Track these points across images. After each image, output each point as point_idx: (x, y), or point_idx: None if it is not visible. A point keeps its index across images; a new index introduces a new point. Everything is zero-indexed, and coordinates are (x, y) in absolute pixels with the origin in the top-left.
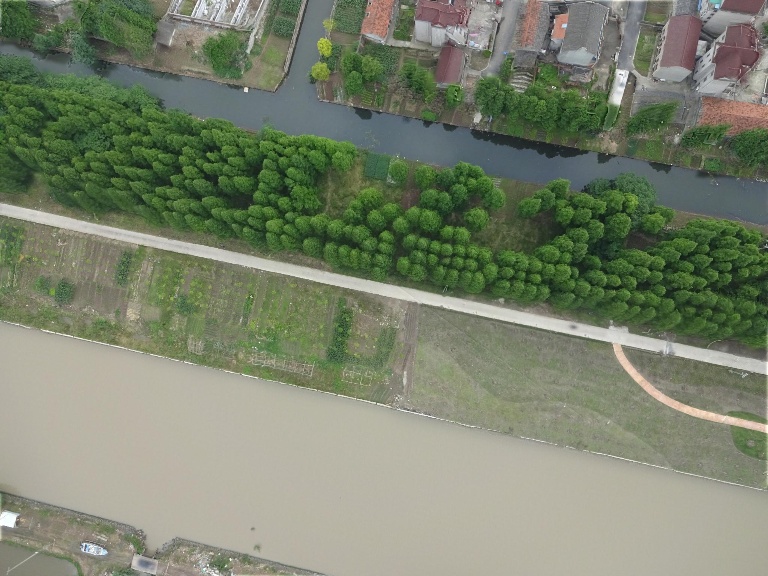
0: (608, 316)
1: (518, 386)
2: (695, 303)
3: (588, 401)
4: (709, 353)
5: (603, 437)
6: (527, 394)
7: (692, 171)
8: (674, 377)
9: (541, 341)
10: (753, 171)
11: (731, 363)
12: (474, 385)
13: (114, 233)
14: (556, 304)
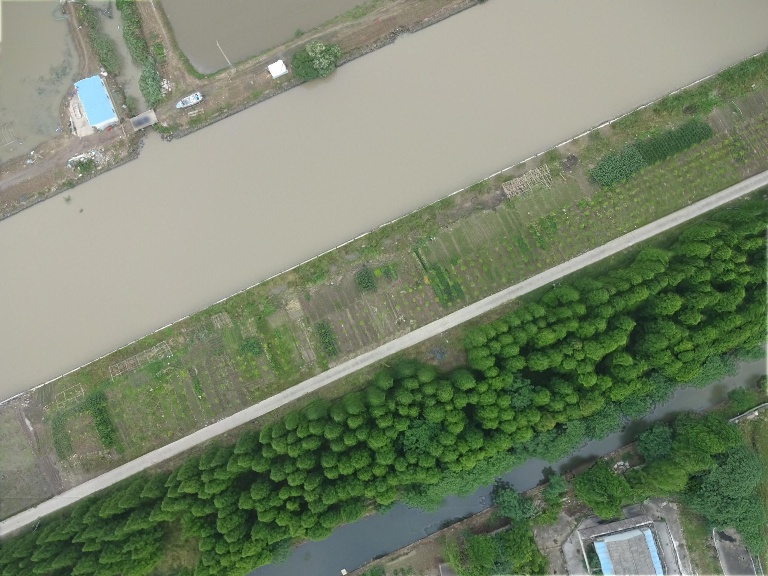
0: None
1: None
2: None
3: None
4: None
5: None
6: None
7: None
8: None
9: None
10: None
11: None
12: None
13: (360, 363)
14: None
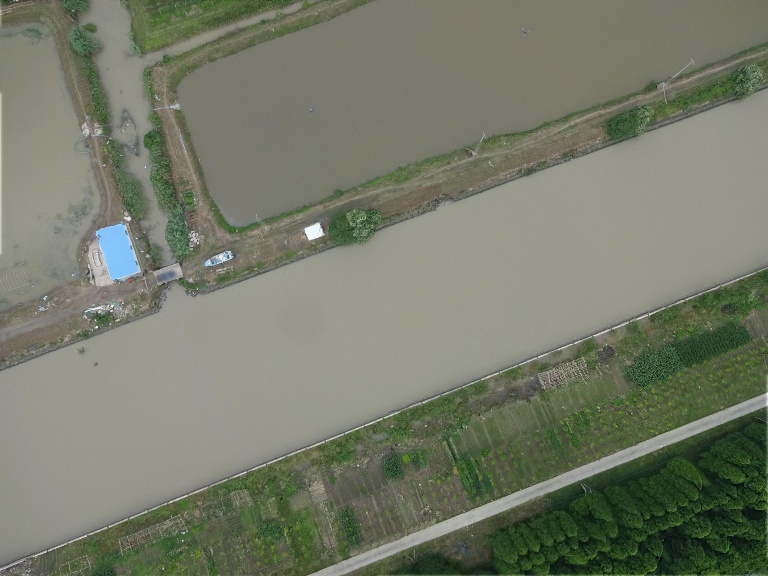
0: None
1: None
2: None
3: None
4: None
5: None
6: None
7: None
8: None
9: None
10: None
11: None
12: None
13: (382, 553)
14: None
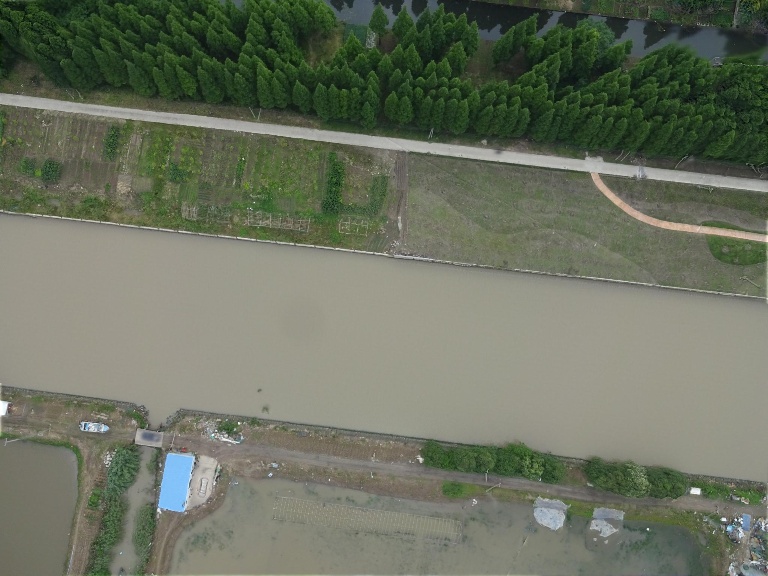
0: (584, 141)
1: (508, 218)
2: (661, 110)
3: (574, 225)
4: (677, 173)
5: (592, 260)
6: (517, 225)
7: (641, 21)
8: (649, 197)
9: (525, 176)
10: (693, 17)
11: (698, 180)
12: (467, 222)
13: (100, 110)
14: (536, 133)
